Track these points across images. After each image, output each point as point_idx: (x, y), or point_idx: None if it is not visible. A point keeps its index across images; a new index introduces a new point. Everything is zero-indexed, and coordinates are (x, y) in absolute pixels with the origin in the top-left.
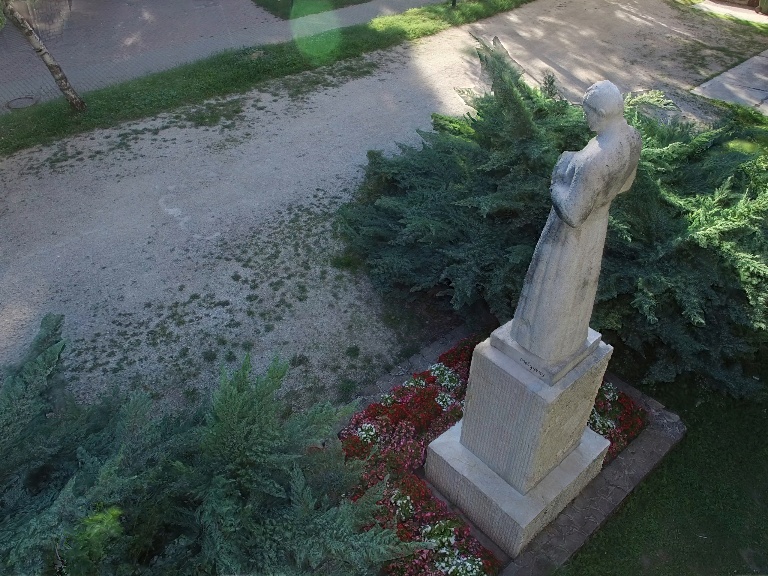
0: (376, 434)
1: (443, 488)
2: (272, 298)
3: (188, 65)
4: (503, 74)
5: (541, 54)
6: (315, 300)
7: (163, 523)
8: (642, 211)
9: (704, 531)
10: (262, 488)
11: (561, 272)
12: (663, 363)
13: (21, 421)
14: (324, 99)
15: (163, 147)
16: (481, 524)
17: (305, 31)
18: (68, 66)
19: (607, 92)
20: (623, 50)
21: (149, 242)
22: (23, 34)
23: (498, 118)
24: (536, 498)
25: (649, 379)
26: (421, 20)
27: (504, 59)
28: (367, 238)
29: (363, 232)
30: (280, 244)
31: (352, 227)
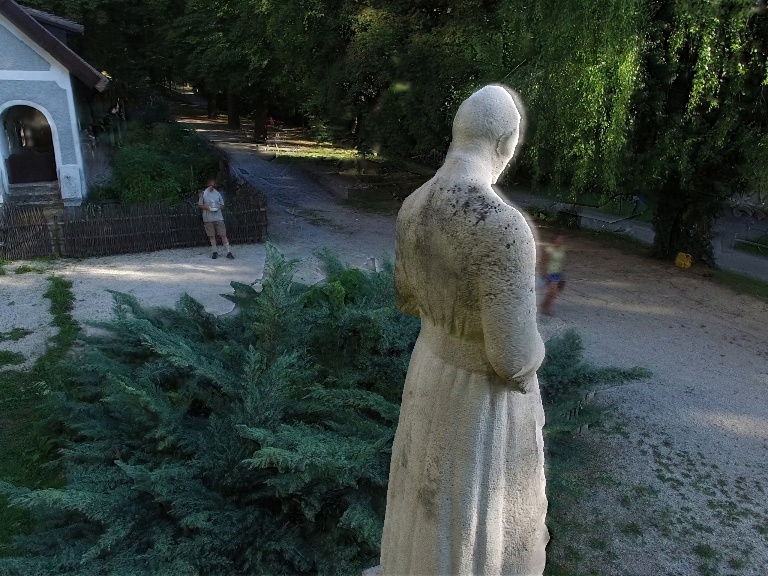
0: None
1: None
2: None
3: None
4: None
5: None
6: None
7: None
8: None
9: None
10: None
11: None
12: None
13: None
14: None
15: None
16: None
17: None
18: None
19: None
20: None
21: None
22: None
23: None
24: None
25: None
26: None
27: None
28: None
29: None
30: None
31: None
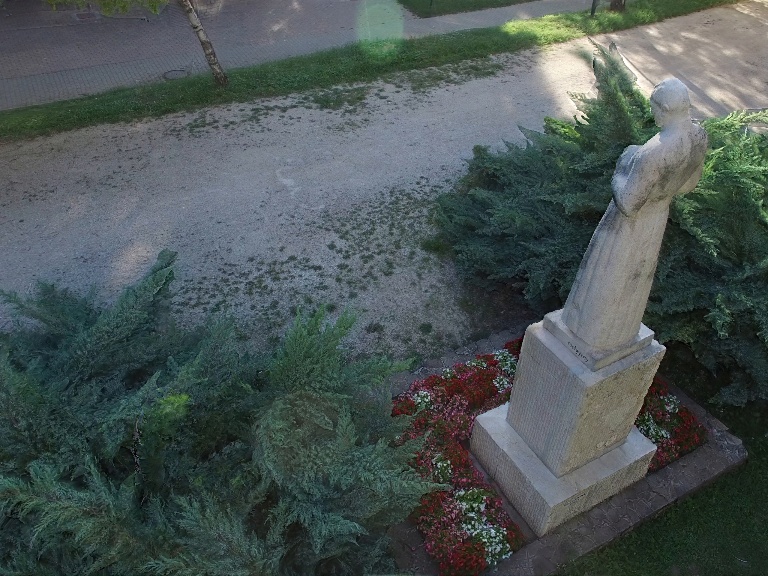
0: (431, 401)
1: (484, 461)
2: (361, 269)
3: (324, 52)
4: (610, 78)
5: (675, 70)
6: (400, 276)
7: (226, 432)
8: (736, 229)
9: (745, 555)
10: (314, 419)
11: (613, 259)
12: (736, 386)
13: (128, 326)
14: (444, 94)
15: (288, 124)
16: (514, 500)
17: (440, 30)
18: (220, 45)
19: (673, 88)
20: (767, 73)
21: (261, 205)
22: (184, 11)
23: (602, 122)
24: (569, 483)
25: (717, 399)
26: (555, 27)
27: (618, 65)
28: (458, 226)
29: (455, 220)
30: (377, 222)
31: (446, 214)
